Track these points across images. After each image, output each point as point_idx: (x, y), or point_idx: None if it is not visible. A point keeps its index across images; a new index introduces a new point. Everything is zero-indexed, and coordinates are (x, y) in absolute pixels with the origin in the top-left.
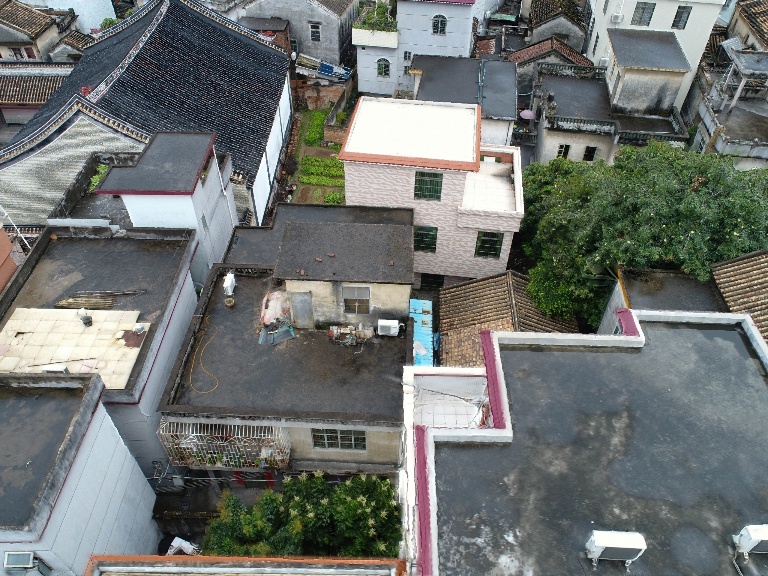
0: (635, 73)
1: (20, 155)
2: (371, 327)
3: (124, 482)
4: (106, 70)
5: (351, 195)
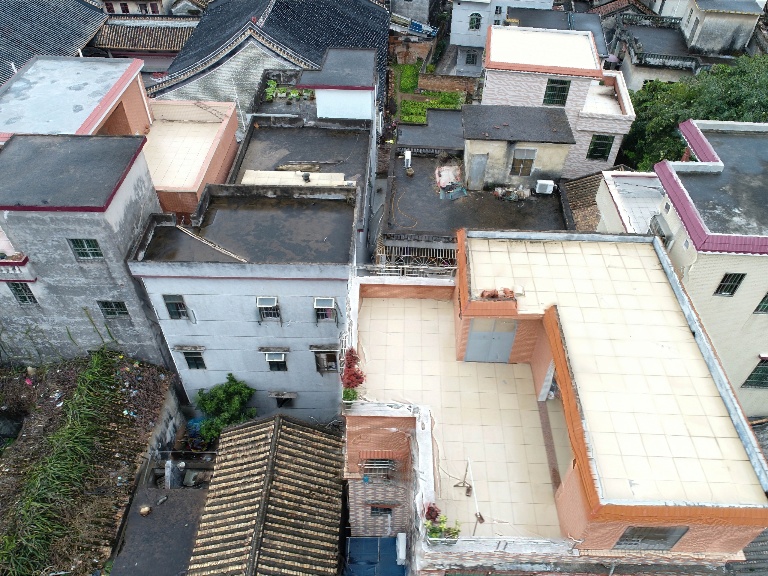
0: (714, 16)
1: (192, 77)
2: (528, 189)
3: None
4: (242, 16)
5: (489, 102)
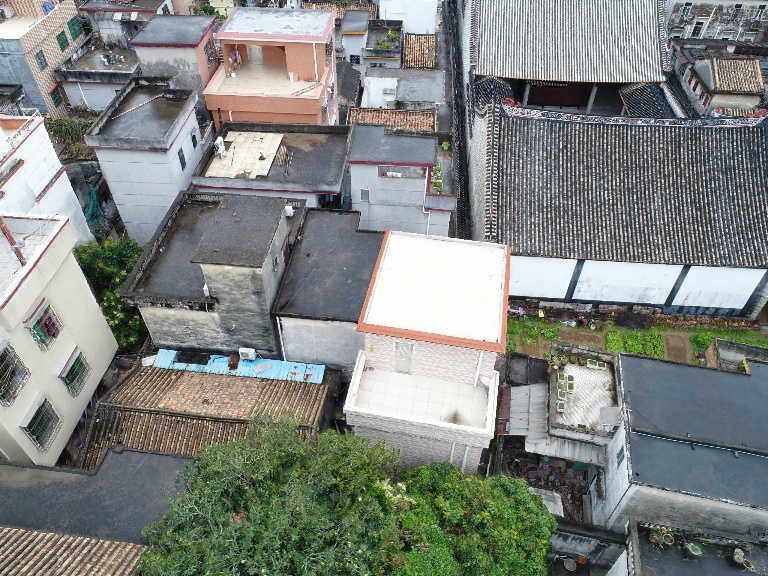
0: None
1: None
2: None
3: (167, 202)
4: None
5: None
